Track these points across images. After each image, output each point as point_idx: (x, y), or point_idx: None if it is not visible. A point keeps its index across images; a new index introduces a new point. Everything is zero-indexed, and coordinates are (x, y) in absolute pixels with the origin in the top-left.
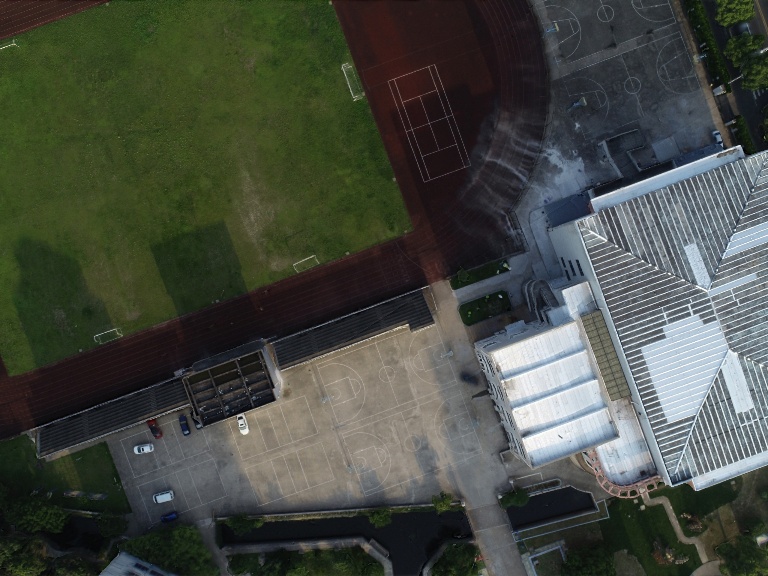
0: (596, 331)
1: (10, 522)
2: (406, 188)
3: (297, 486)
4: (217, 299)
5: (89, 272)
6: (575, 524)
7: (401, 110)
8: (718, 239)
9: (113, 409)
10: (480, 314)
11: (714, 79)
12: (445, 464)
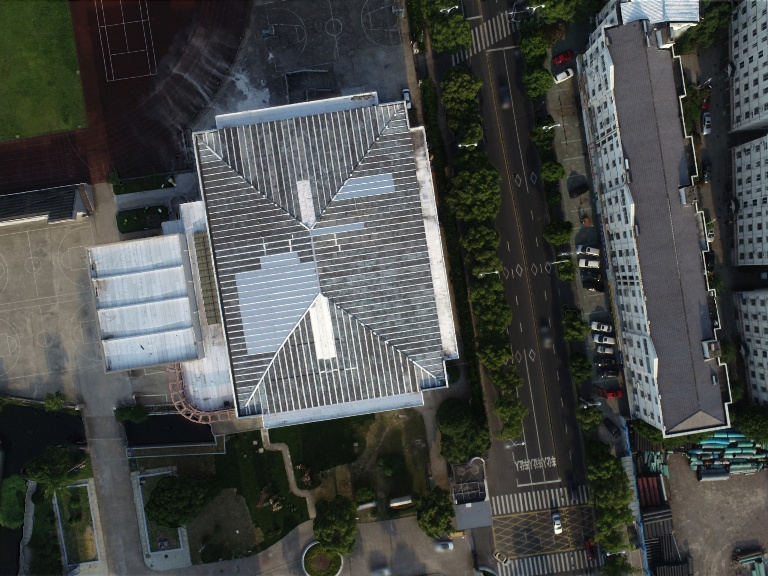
0: (204, 251)
1: None
2: (88, 83)
3: None
4: None
5: None
6: (191, 453)
7: (98, 4)
8: (332, 180)
9: None
10: (137, 224)
11: (413, 36)
12: (73, 366)
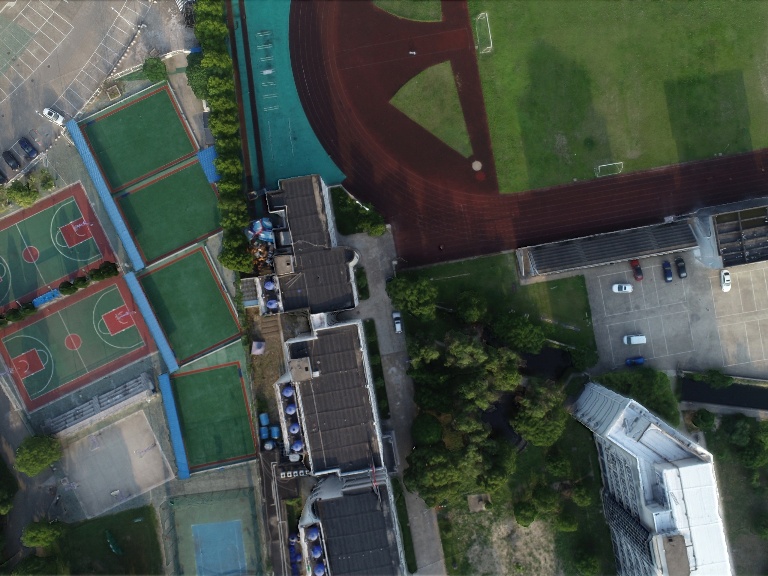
0: None
1: (497, 333)
2: None
3: (766, 353)
4: (720, 152)
5: (598, 103)
6: None
7: None
8: None
9: (608, 241)
10: None
11: None
12: None
